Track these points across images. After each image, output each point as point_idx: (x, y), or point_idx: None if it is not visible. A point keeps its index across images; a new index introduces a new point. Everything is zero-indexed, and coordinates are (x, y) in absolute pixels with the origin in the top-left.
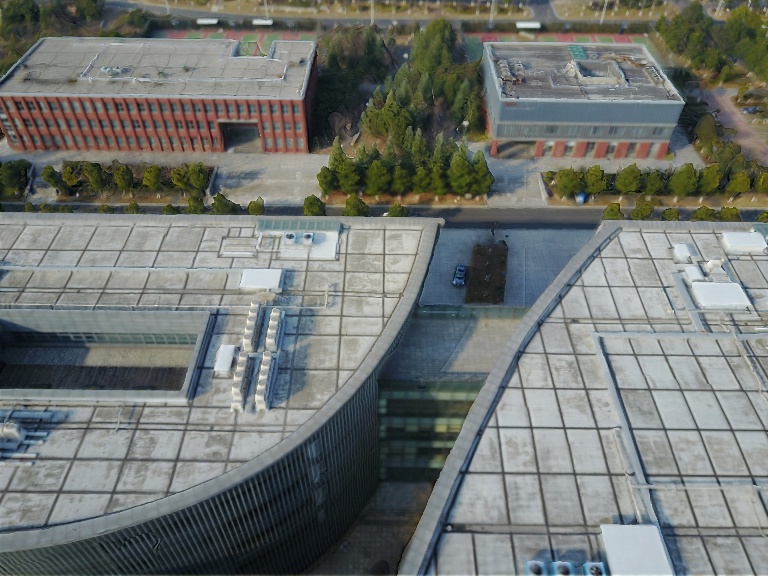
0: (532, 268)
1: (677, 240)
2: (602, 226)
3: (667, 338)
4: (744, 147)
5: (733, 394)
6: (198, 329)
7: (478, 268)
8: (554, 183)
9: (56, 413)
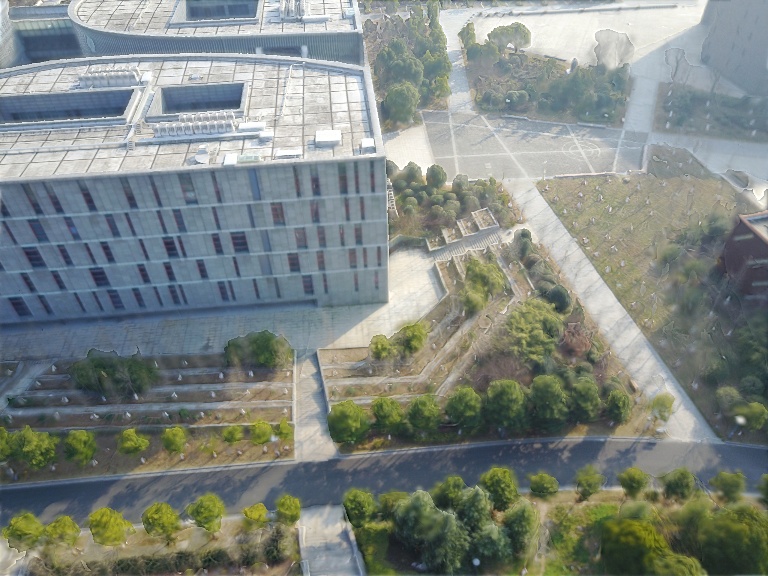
0: None
1: None
2: None
3: None
4: None
5: None
6: None
7: None
8: None
9: None
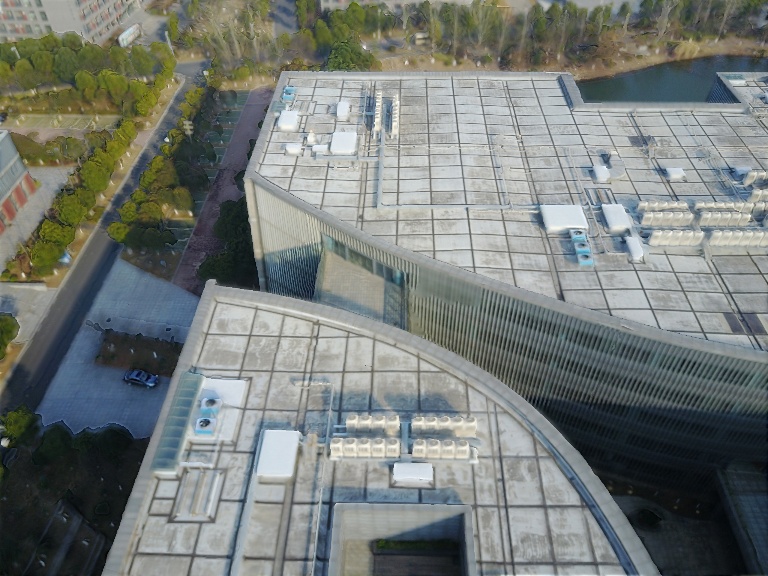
0: (152, 316)
1: (276, 149)
2: (249, 182)
3: (383, 175)
4: (50, 140)
5: (432, 159)
6: (343, 535)
7: (135, 362)
8: (25, 274)
9: None
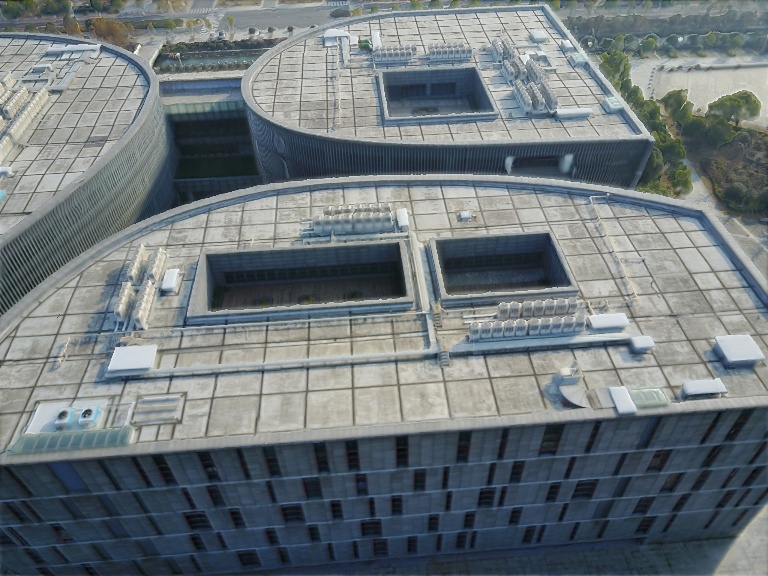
0: None
1: None
2: None
3: None
4: None
5: None
6: None
7: None
8: None
9: (301, 244)
